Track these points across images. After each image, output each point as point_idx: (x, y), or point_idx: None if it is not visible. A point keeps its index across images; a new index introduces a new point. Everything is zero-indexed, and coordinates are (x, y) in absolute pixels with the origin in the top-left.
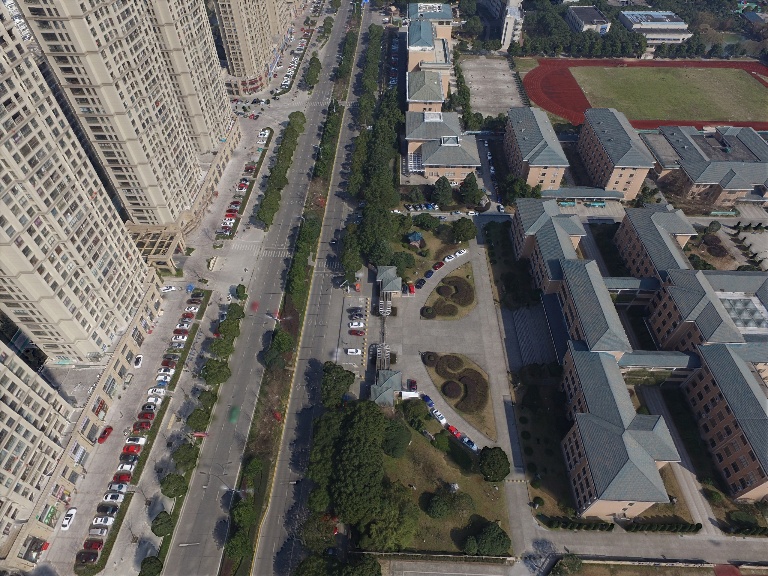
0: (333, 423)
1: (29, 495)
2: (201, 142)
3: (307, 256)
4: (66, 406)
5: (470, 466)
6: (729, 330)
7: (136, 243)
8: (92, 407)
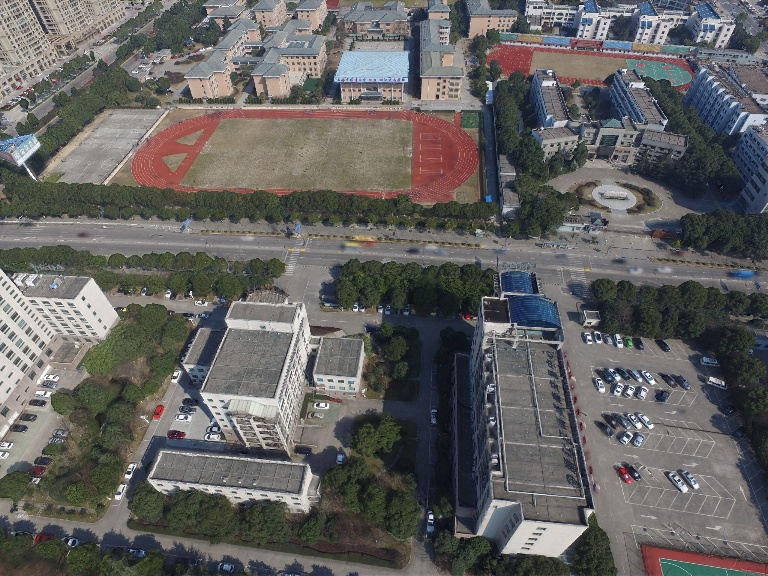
0: None
1: None
2: (94, 8)
3: (132, 49)
4: (2, 70)
5: (161, 93)
6: (274, 42)
7: None
8: None
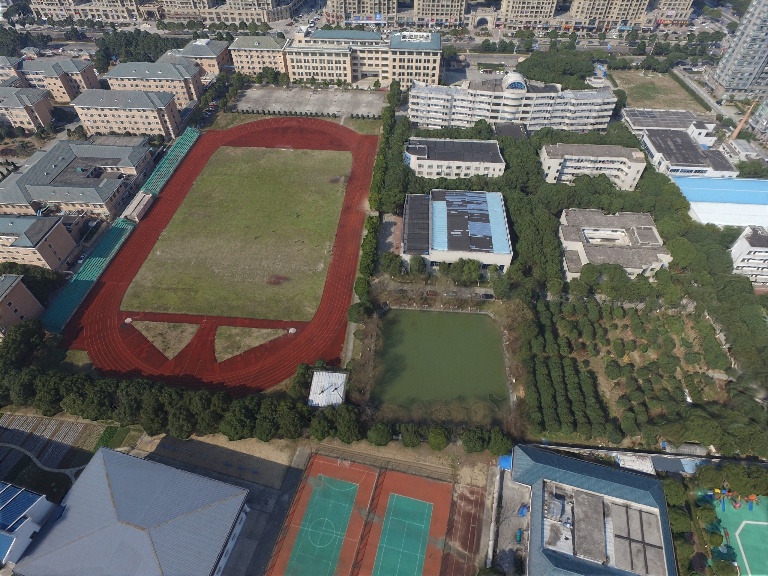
0: (18, 33)
1: (45, 2)
2: None
3: None
4: (72, 1)
5: None
6: None
7: (156, 3)
8: (74, 8)
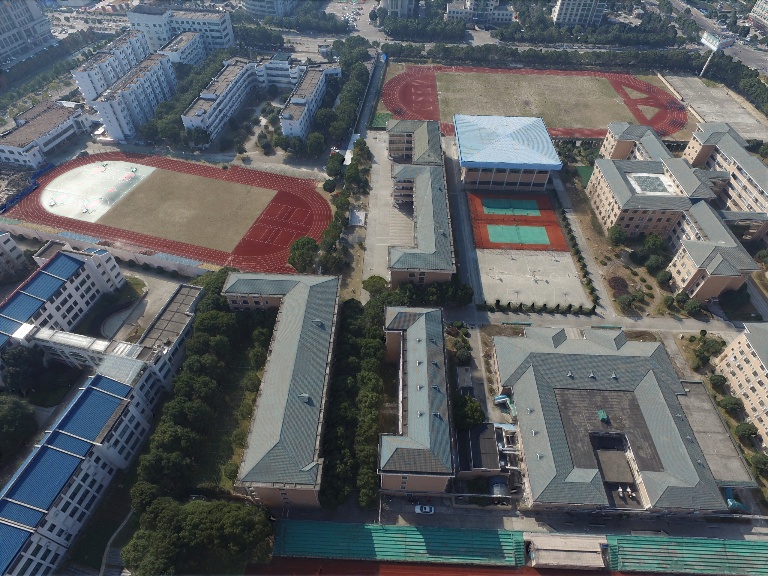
0: None
1: None
2: None
3: None
4: None
5: None
6: None
7: None
8: None
